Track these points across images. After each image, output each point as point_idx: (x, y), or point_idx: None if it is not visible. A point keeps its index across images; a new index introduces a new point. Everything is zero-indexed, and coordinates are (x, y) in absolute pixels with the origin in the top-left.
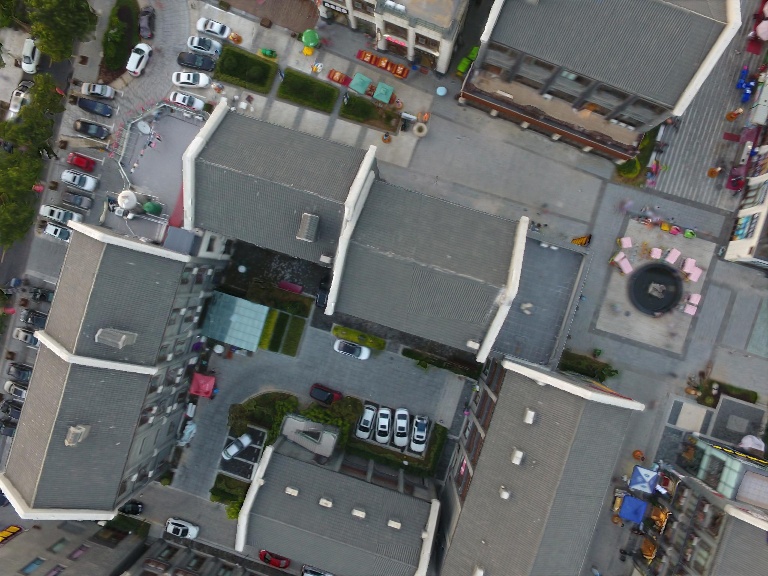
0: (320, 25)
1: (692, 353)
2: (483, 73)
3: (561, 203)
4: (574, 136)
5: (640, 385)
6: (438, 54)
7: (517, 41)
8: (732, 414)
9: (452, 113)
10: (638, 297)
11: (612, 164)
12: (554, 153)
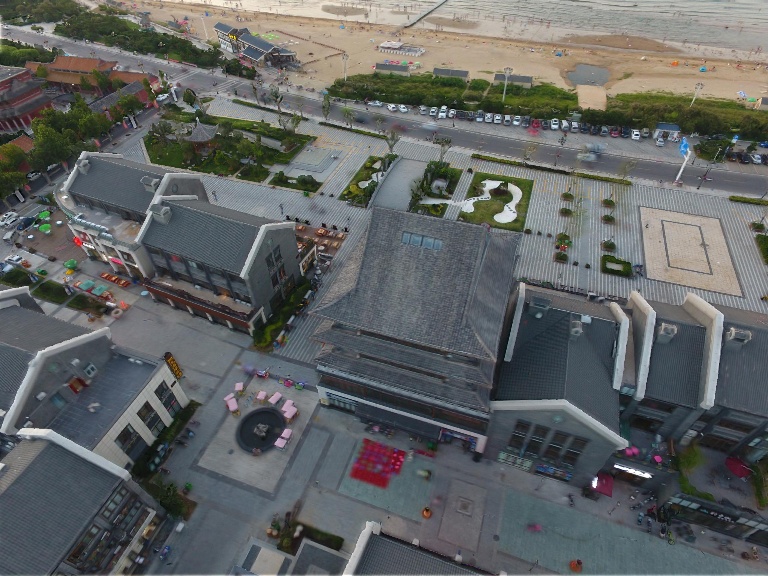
0: (87, 261)
1: (284, 492)
2: (161, 275)
3: (204, 363)
4: (210, 310)
5: (222, 527)
6: (137, 266)
7: (156, 243)
8: (312, 564)
9: (148, 306)
10: (245, 437)
11: (251, 338)
12: (211, 331)
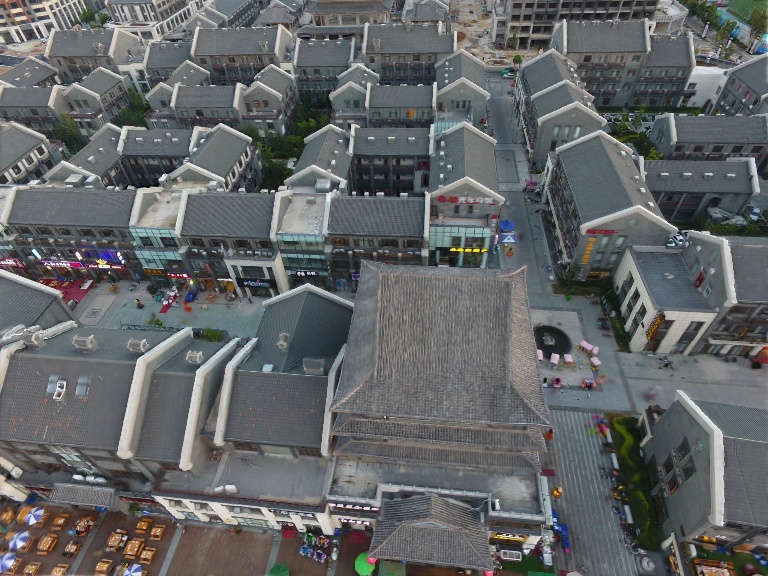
0: None
1: None
2: None
3: (659, 389)
4: None
5: None
6: None
7: None
8: None
9: None
10: (558, 335)
11: None
12: None
